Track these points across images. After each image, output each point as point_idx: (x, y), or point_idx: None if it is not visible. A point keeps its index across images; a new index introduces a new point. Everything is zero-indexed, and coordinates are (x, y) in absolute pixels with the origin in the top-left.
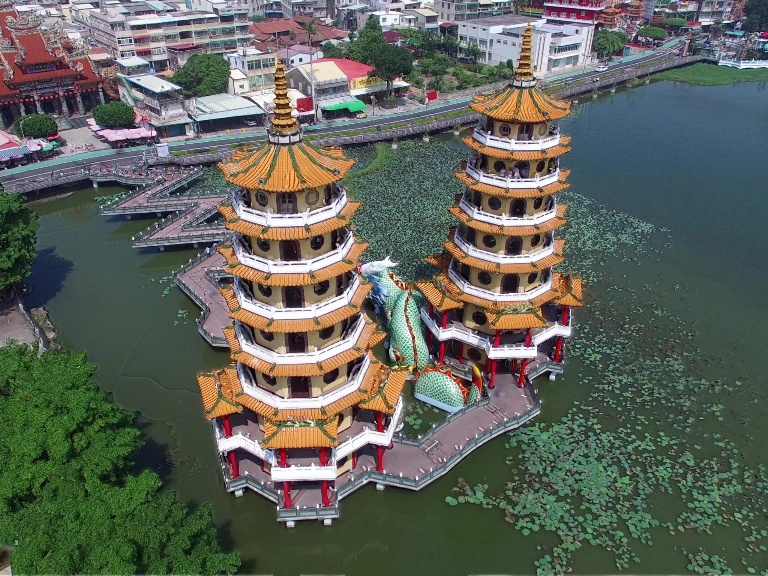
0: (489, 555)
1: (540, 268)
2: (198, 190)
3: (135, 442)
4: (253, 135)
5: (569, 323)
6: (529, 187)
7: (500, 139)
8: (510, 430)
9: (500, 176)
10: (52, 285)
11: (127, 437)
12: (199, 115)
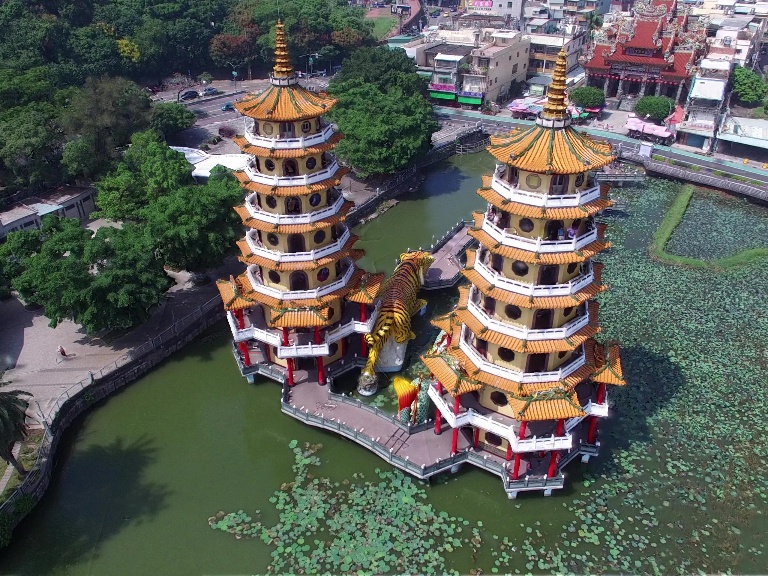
0: (245, 480)
1: (486, 337)
2: (620, 191)
3: (216, 246)
4: (765, 174)
5: (525, 439)
6: (495, 237)
7: (496, 172)
8: (380, 457)
9: (489, 213)
10: (427, 195)
11: (197, 233)
12: (725, 133)
